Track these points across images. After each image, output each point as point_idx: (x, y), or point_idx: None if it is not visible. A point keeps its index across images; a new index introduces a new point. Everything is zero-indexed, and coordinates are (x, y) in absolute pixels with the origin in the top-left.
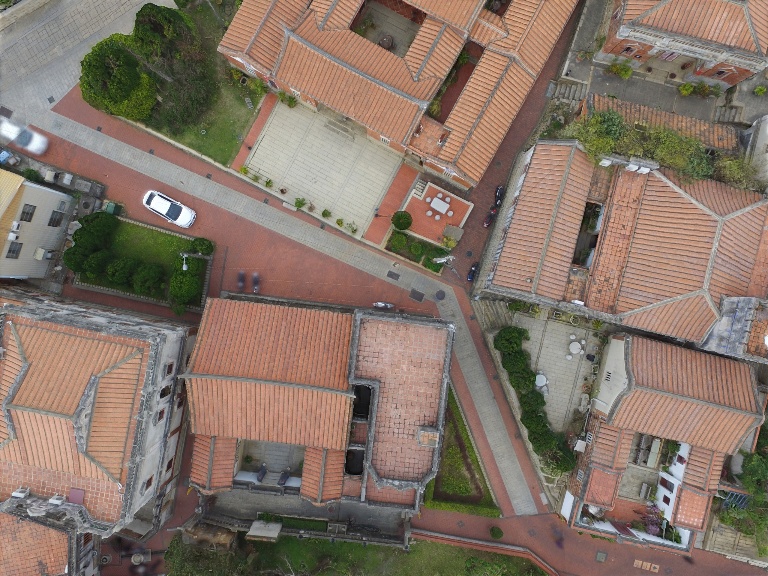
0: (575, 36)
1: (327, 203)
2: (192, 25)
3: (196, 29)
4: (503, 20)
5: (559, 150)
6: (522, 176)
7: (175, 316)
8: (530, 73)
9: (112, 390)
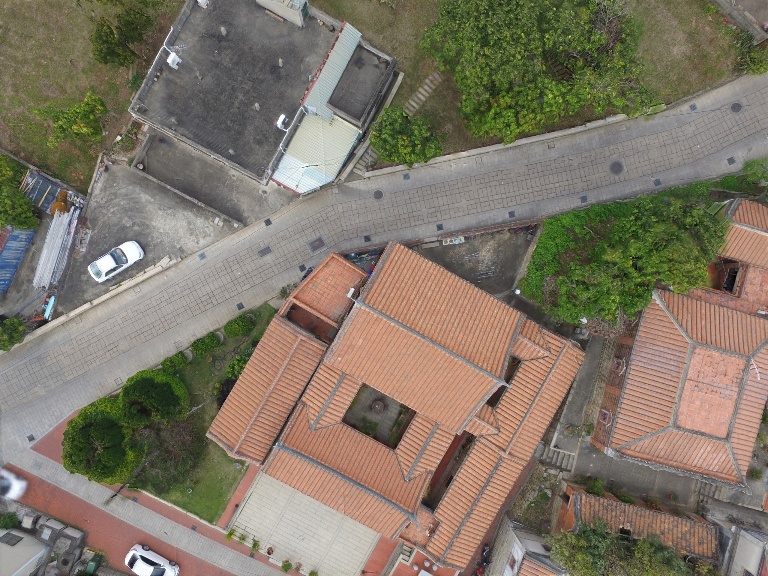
0: (564, 410)
1: (314, 560)
2: (181, 392)
3: (185, 395)
4: (495, 414)
5: (546, 574)
6: (509, 569)
7: None
8: (519, 463)
9: None
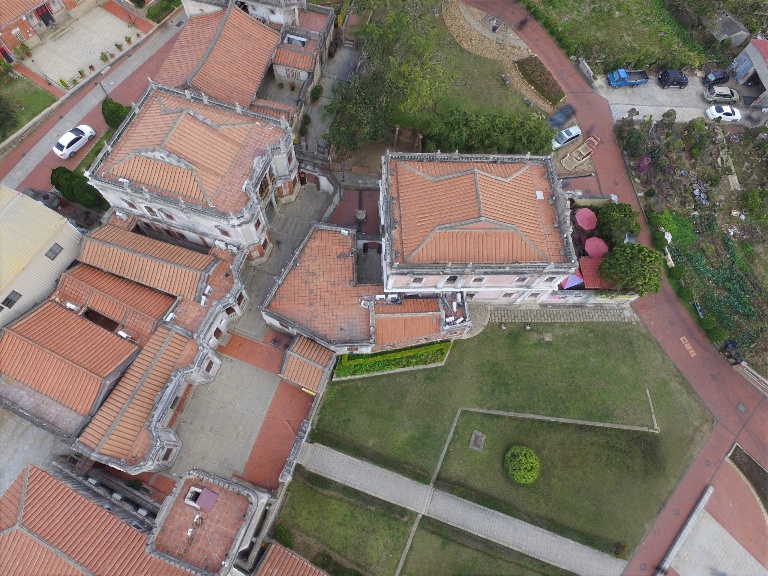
0: None
1: (112, 48)
2: None
3: None
4: None
5: None
6: None
7: None
8: None
9: None
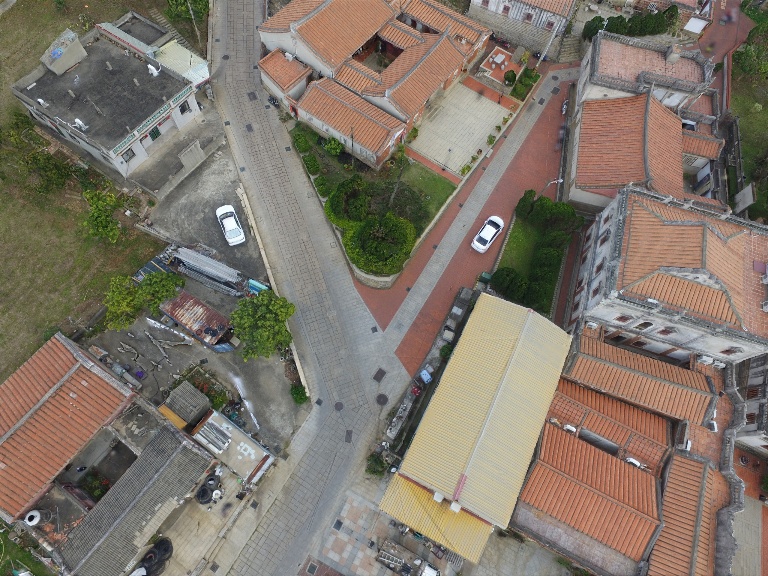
0: None
1: (489, 129)
2: None
3: None
4: None
5: None
6: (490, 5)
7: (573, 254)
8: None
9: (671, 218)
